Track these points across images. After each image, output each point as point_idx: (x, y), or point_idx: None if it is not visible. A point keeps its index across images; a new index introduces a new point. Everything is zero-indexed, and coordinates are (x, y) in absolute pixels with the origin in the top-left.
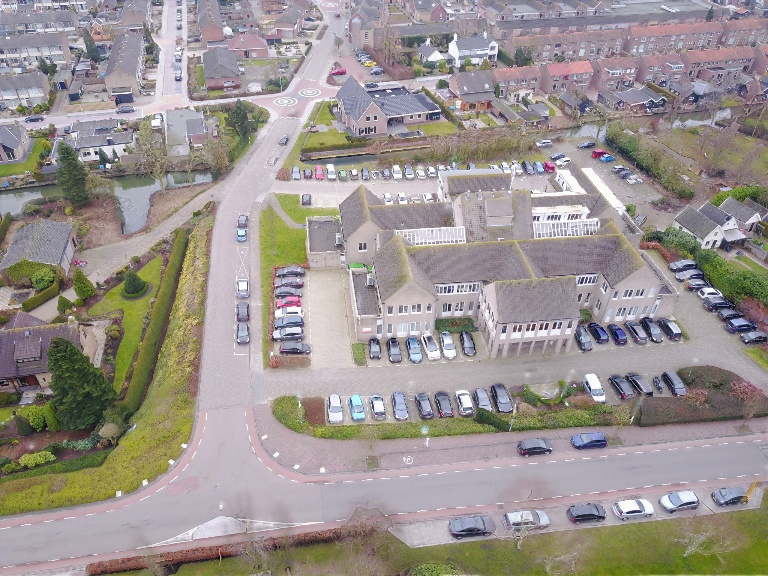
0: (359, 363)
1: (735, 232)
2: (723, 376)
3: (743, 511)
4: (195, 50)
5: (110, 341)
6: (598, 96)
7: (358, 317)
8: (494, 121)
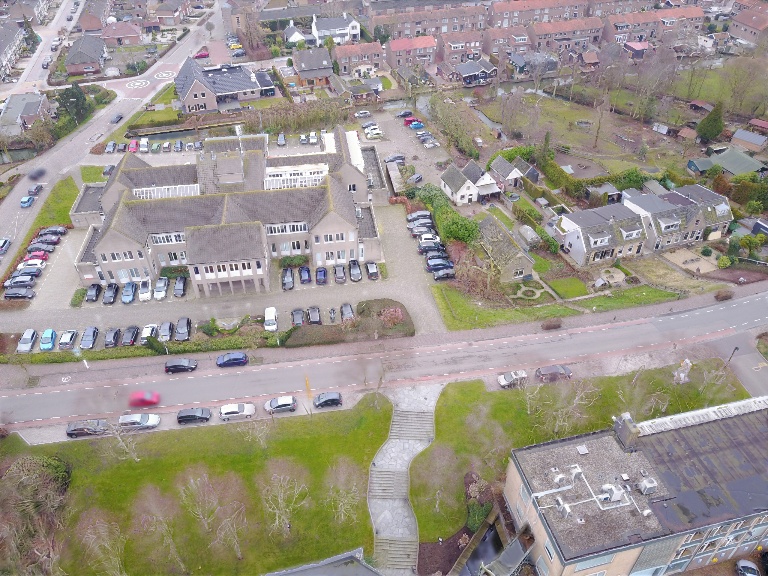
0: (73, 305)
1: (492, 187)
2: (390, 306)
3: (335, 412)
4: (75, 40)
5: None
6: (437, 69)
7: (74, 264)
8: (328, 95)
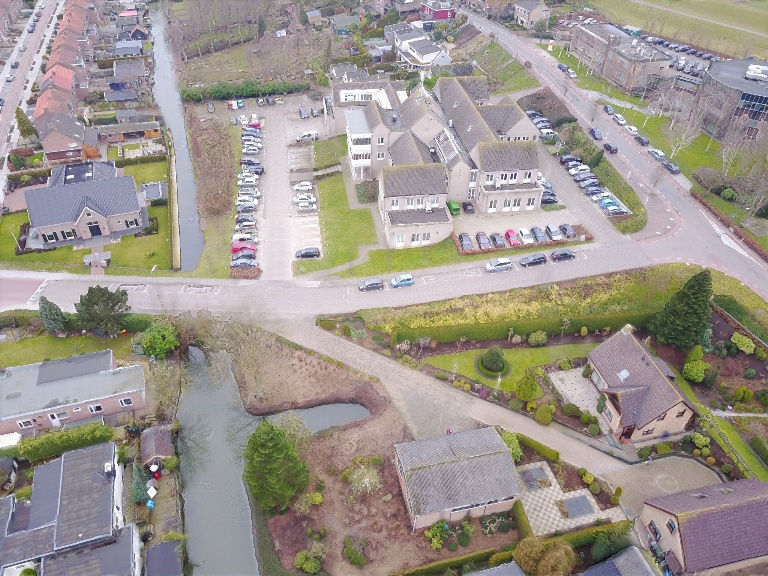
0: None
1: None
2: None
3: None
4: None
5: (580, 361)
6: (110, 86)
7: None
8: (133, 144)
